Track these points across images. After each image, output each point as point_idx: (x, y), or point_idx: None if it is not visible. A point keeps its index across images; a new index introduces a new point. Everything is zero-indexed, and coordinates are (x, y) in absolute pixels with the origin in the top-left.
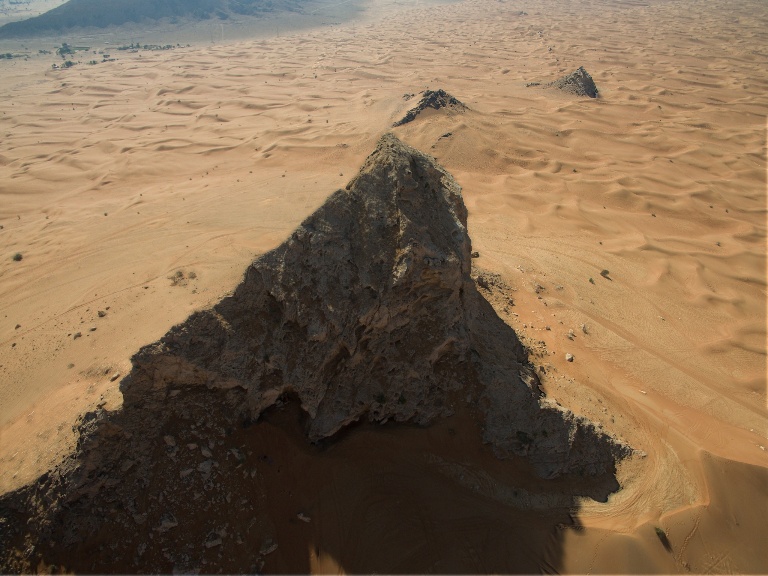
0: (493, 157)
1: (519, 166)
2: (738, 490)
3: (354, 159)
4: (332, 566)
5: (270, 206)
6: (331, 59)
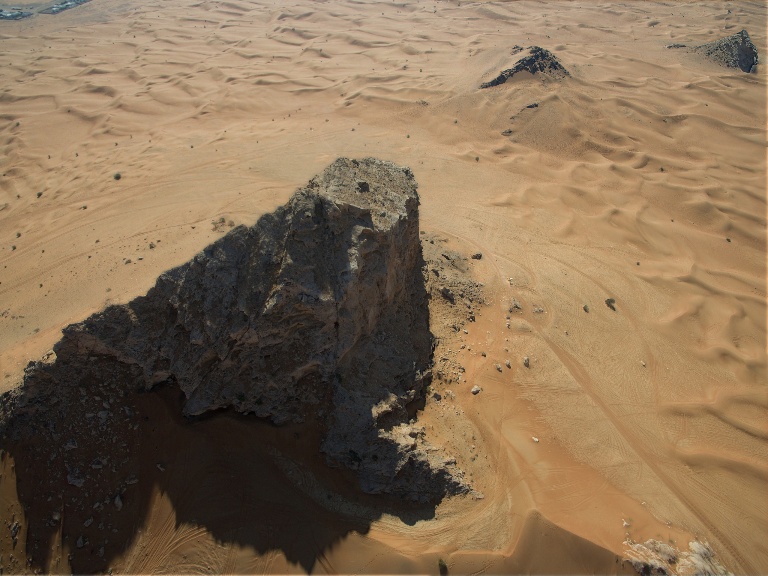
0: (575, 138)
1: (600, 153)
2: (549, 553)
3: (428, 120)
4: (169, 506)
5: (324, 163)
6: None
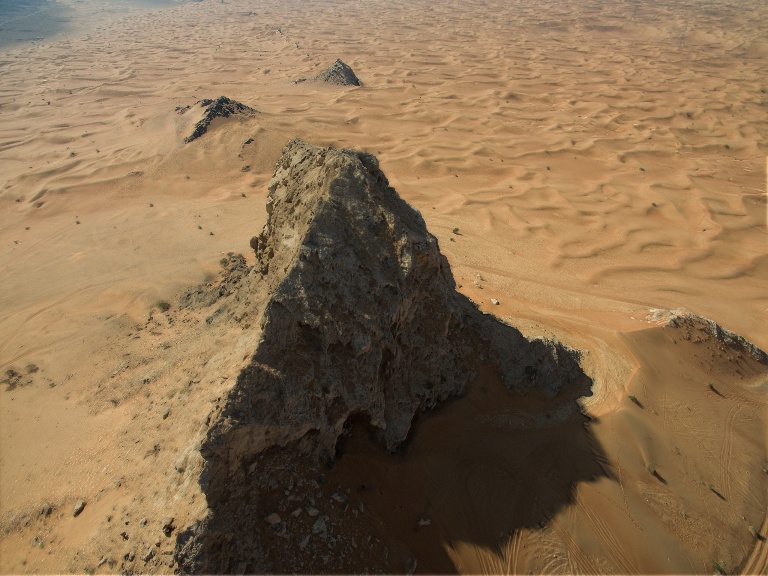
0: None
1: None
2: (647, 350)
3: (157, 185)
4: (468, 549)
5: (86, 260)
6: (57, 80)
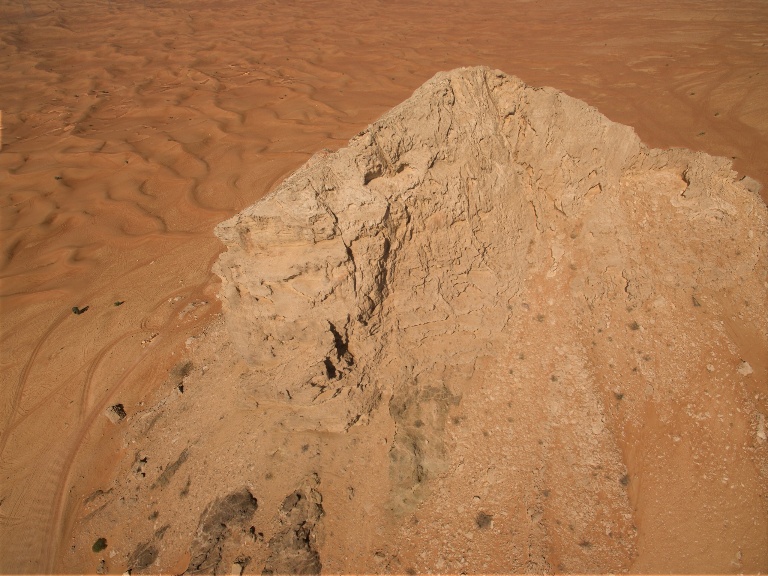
0: None
1: None
2: None
3: None
4: None
5: None
6: None
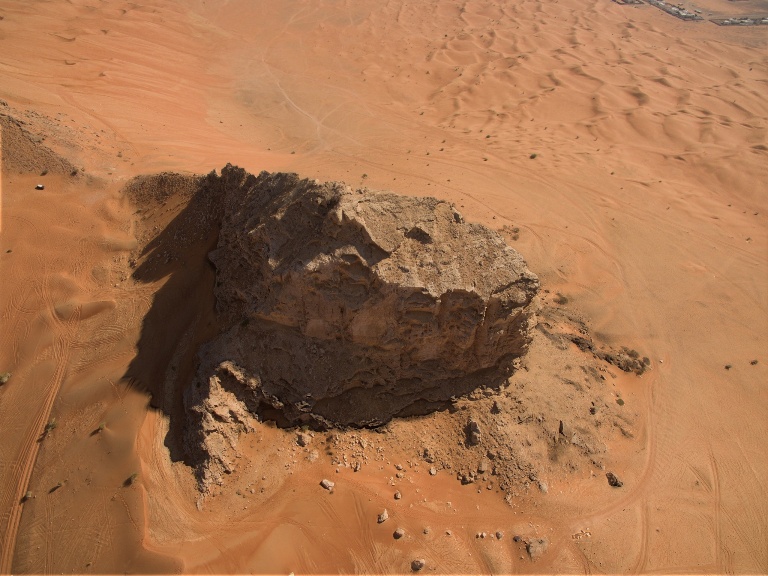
0: None
1: None
2: None
3: None
4: None
5: (683, 270)
6: None
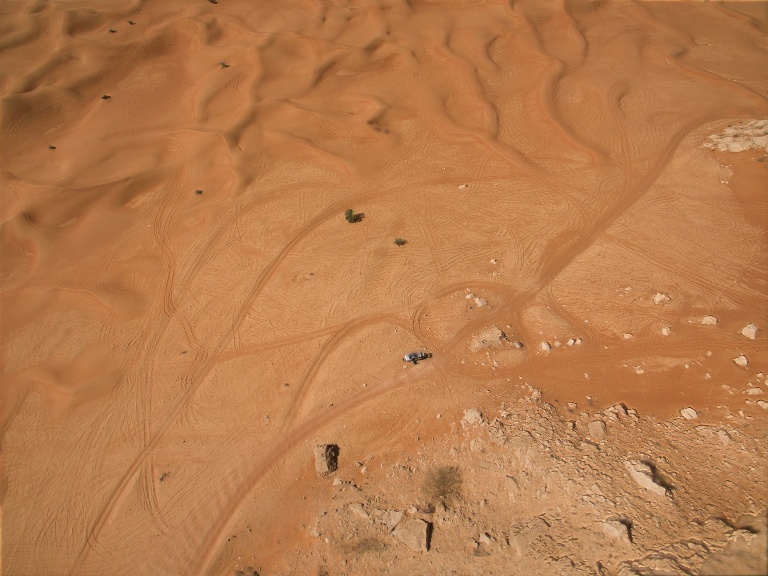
0: None
1: None
2: None
3: None
4: None
5: None
6: None
